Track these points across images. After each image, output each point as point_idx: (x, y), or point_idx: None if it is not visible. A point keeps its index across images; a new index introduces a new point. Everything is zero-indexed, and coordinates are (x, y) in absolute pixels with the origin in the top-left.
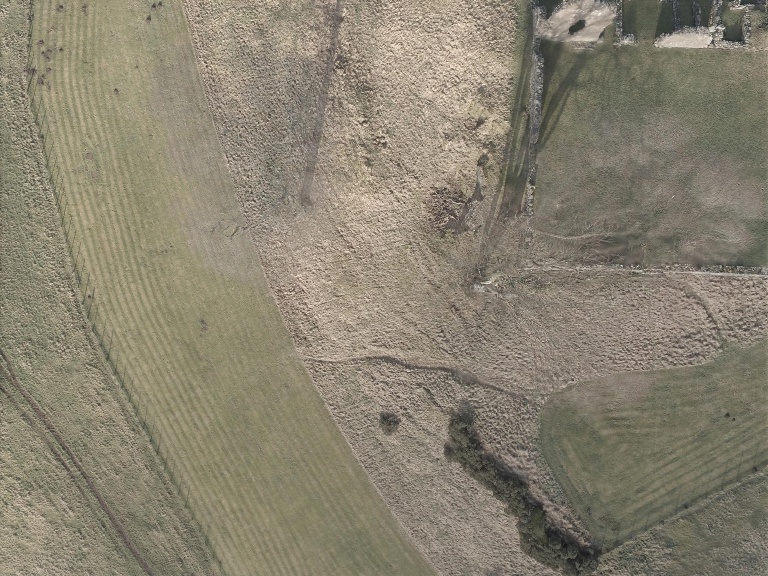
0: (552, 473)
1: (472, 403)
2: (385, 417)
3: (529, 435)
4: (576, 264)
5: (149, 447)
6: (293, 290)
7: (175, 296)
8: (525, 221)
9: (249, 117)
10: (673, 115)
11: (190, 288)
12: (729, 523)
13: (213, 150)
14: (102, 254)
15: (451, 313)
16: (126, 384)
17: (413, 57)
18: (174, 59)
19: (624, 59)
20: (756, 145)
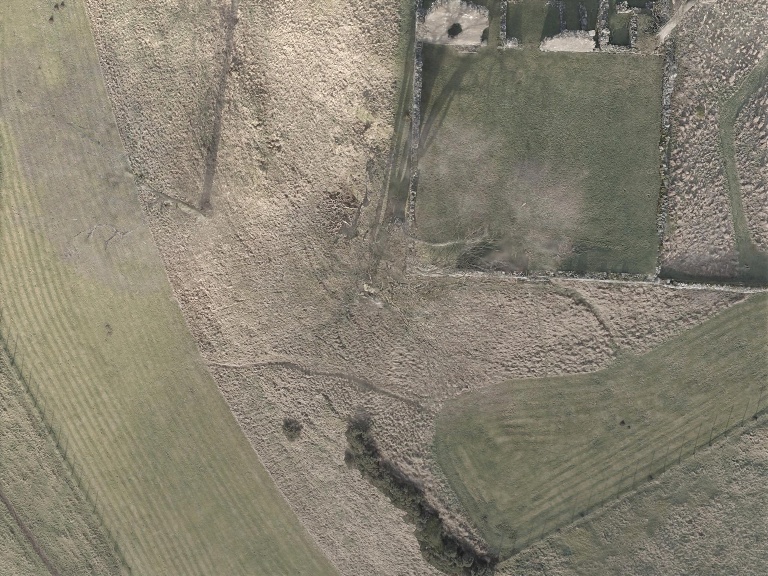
0: (447, 481)
1: (368, 410)
2: (288, 423)
3: (424, 442)
4: (457, 271)
5: (56, 452)
6: (196, 295)
7: (80, 300)
8: (399, 227)
9: (151, 119)
10: (559, 120)
11: (95, 292)
12: (625, 531)
13: (116, 153)
14: (6, 257)
15: (346, 319)
16: (32, 389)
17: (304, 60)
18: (77, 60)
19: (509, 63)
20: (642, 151)
